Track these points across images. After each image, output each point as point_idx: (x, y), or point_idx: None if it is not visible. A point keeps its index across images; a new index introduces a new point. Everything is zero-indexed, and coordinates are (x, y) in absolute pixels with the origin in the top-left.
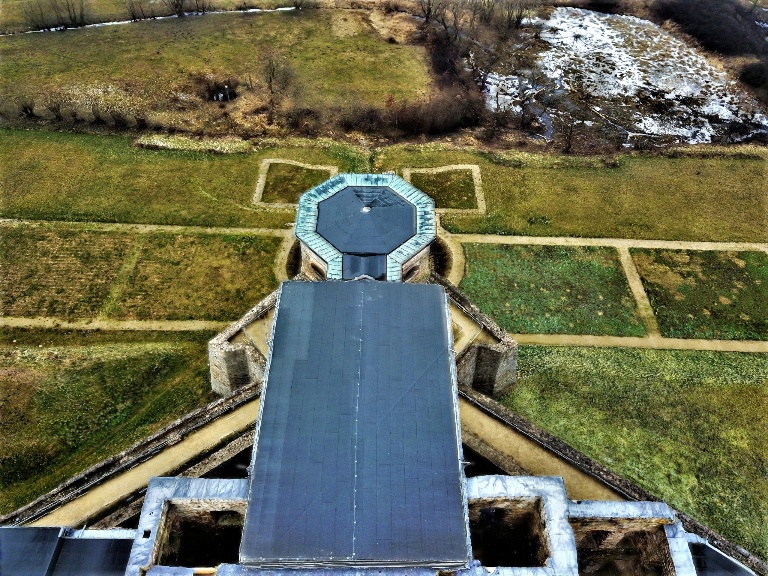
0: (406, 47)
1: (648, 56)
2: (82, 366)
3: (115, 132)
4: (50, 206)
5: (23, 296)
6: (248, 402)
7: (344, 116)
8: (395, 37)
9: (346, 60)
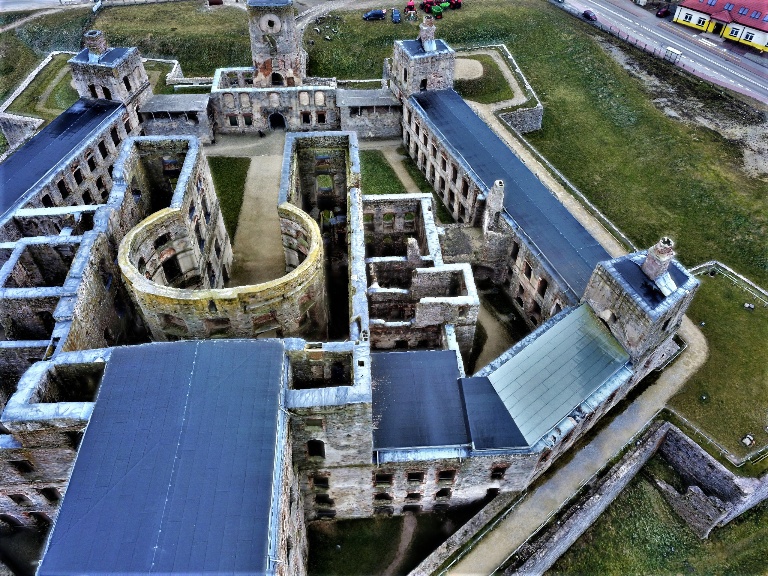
0: None
1: None
2: None
3: None
4: None
5: None
6: None
7: None
8: None
9: None
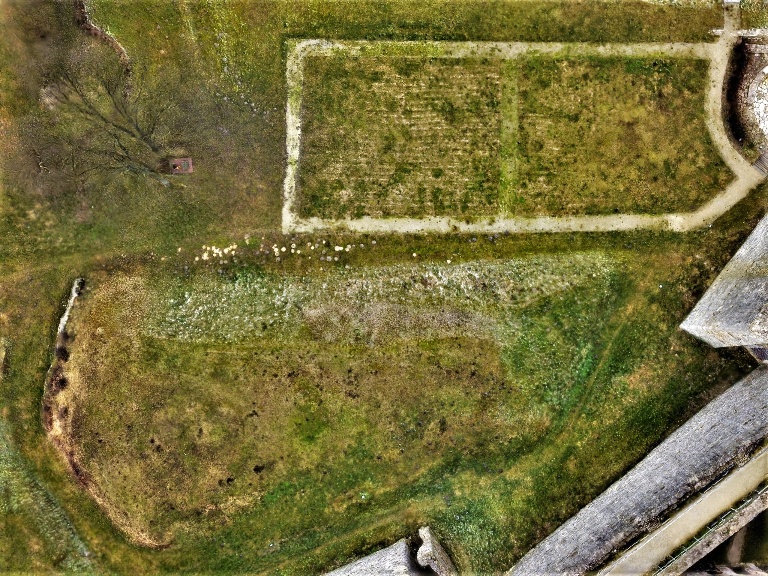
0: None
1: None
2: (526, 302)
3: None
4: (361, 10)
5: (394, 183)
6: None
7: None
8: None
9: None
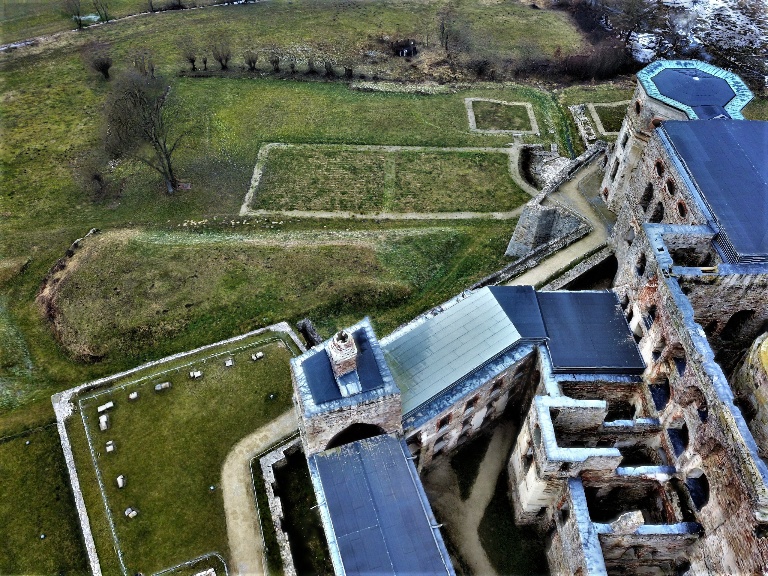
0: (549, 12)
1: (763, 16)
2: (396, 239)
3: (330, 80)
4: (306, 133)
5: (316, 196)
6: (575, 242)
7: (516, 66)
8: (535, 4)
9: (502, 22)
